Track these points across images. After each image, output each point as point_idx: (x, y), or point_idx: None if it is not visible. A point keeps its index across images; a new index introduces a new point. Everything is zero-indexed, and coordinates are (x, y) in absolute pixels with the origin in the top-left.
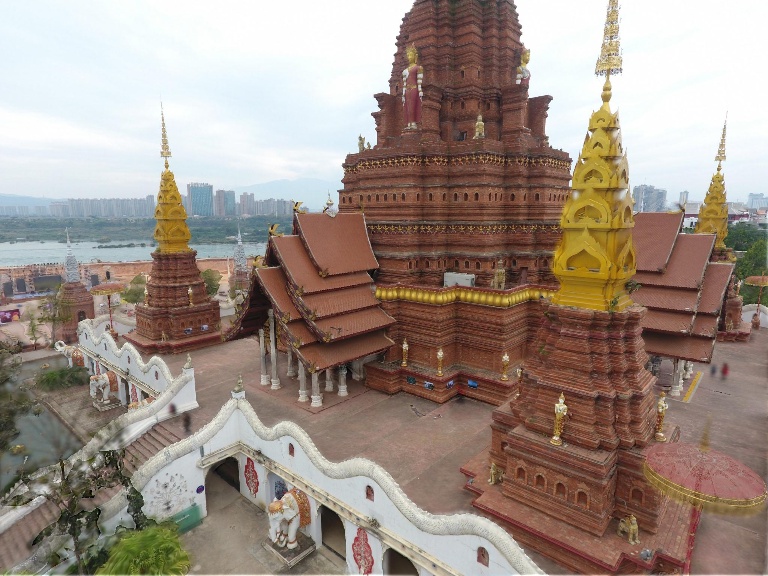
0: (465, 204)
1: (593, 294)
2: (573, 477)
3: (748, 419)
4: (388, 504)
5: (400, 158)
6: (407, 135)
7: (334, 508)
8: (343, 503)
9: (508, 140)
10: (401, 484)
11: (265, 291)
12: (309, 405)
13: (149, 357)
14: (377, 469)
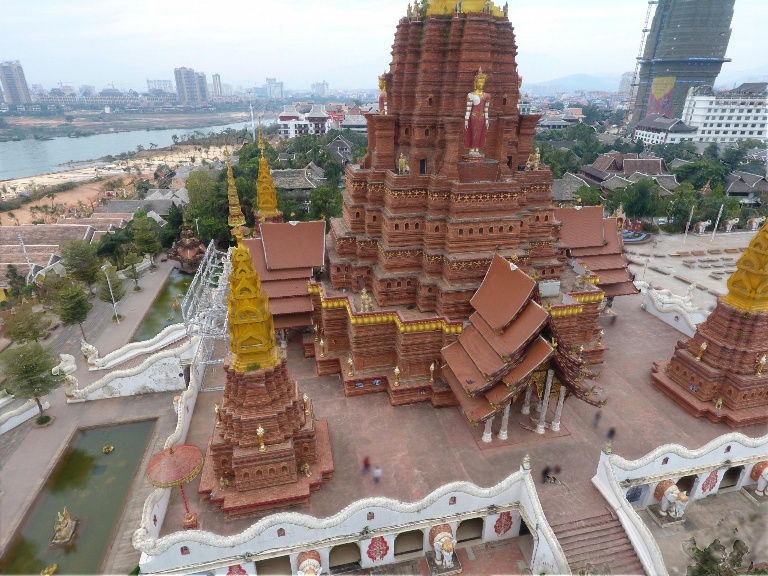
0: (536, 225)
1: (764, 303)
2: (767, 386)
3: (642, 314)
4: (740, 447)
5: (507, 194)
6: (480, 163)
7: (697, 472)
8: (705, 465)
9: (525, 160)
10: (688, 437)
11: (561, 364)
12: (553, 432)
13: (319, 502)
14: (737, 435)
